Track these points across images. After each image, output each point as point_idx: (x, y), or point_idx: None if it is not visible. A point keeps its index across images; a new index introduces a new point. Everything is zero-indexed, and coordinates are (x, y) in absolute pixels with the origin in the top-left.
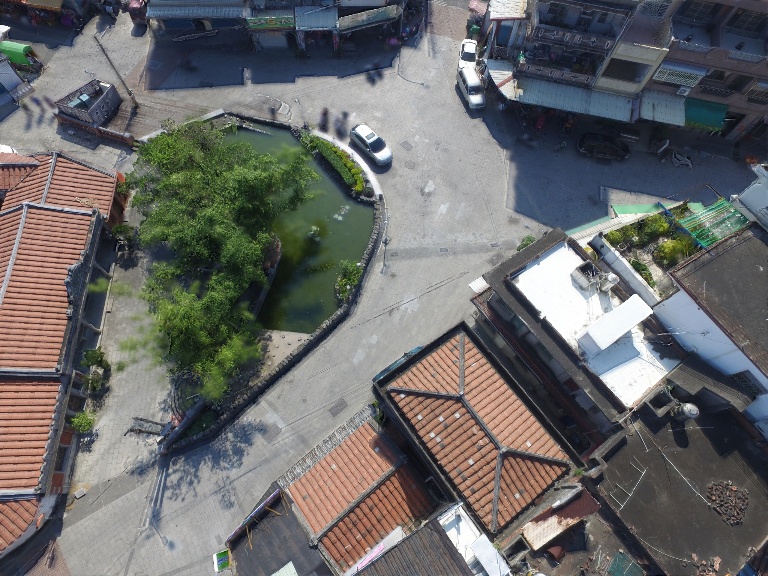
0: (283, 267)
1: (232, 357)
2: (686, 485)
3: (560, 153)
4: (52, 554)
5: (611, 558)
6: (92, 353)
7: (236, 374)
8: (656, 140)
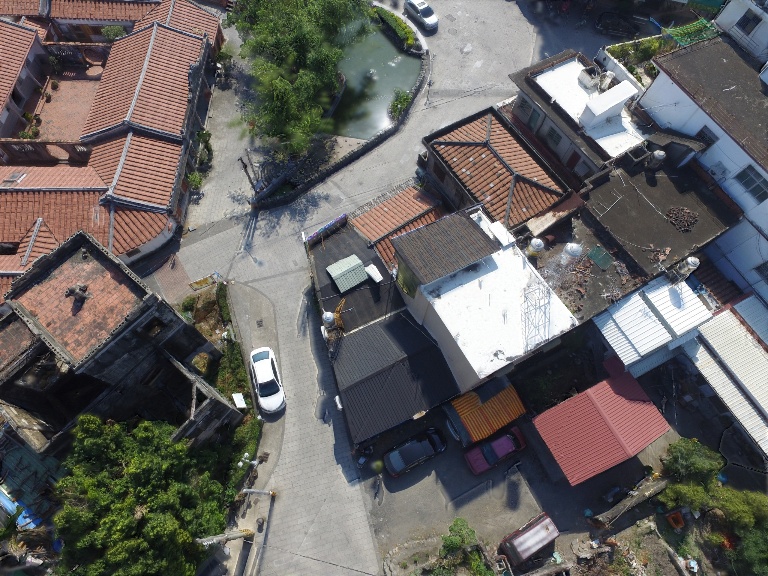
0: (346, 96)
1: (311, 135)
2: (651, 207)
3: (580, 30)
4: (173, 261)
5: (590, 249)
6: (203, 133)
7: (309, 162)
8: (664, 23)
